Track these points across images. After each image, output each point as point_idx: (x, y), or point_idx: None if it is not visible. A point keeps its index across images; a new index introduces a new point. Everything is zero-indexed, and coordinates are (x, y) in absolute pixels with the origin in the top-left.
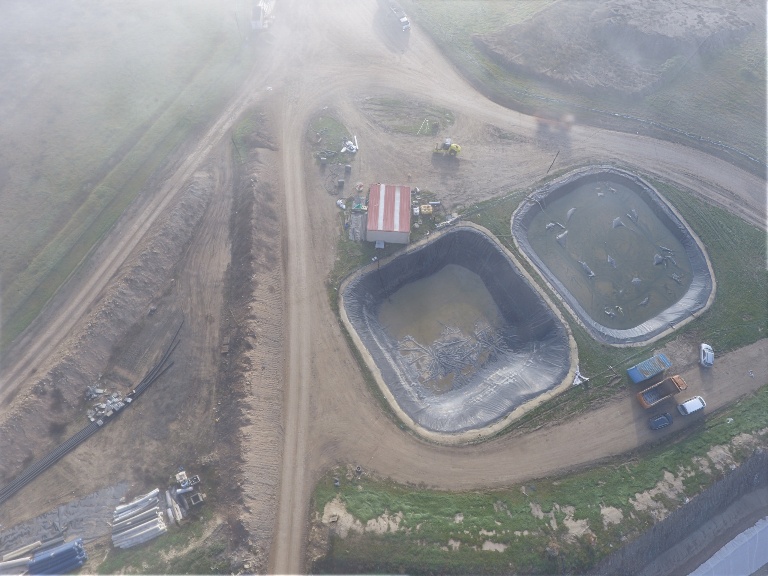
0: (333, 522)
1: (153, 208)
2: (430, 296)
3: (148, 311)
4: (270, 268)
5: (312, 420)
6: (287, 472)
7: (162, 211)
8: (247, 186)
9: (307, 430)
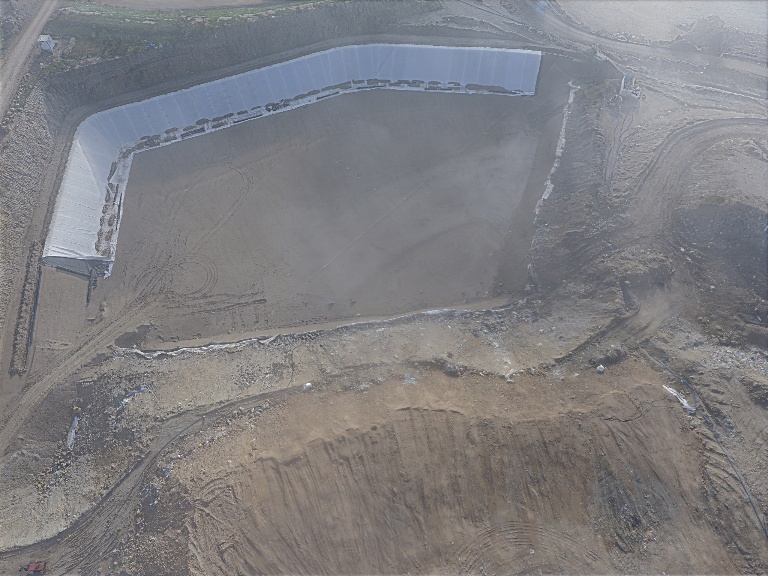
0: (63, 10)
1: None
2: None
3: None
4: None
5: None
6: None
7: None
8: None
9: None
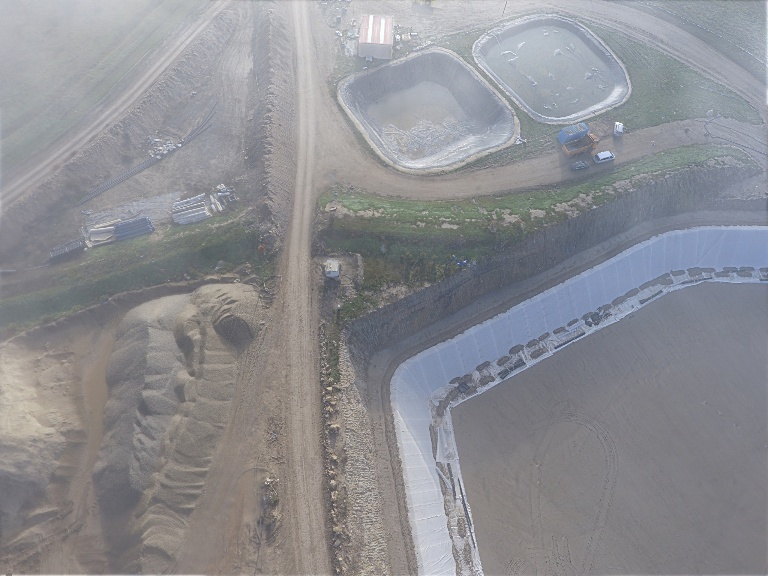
0: (333, 210)
1: (191, 32)
2: (408, 101)
3: (191, 94)
4: (284, 68)
5: (317, 159)
6: (299, 188)
7: (198, 34)
8: (265, 17)
9: (313, 165)
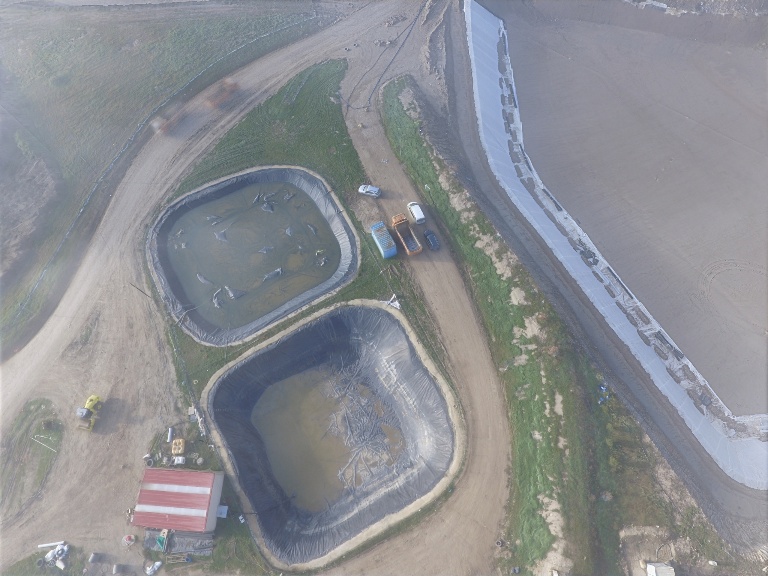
0: (559, 575)
1: None
2: (290, 446)
3: None
4: None
5: None
6: None
7: None
8: None
9: None
